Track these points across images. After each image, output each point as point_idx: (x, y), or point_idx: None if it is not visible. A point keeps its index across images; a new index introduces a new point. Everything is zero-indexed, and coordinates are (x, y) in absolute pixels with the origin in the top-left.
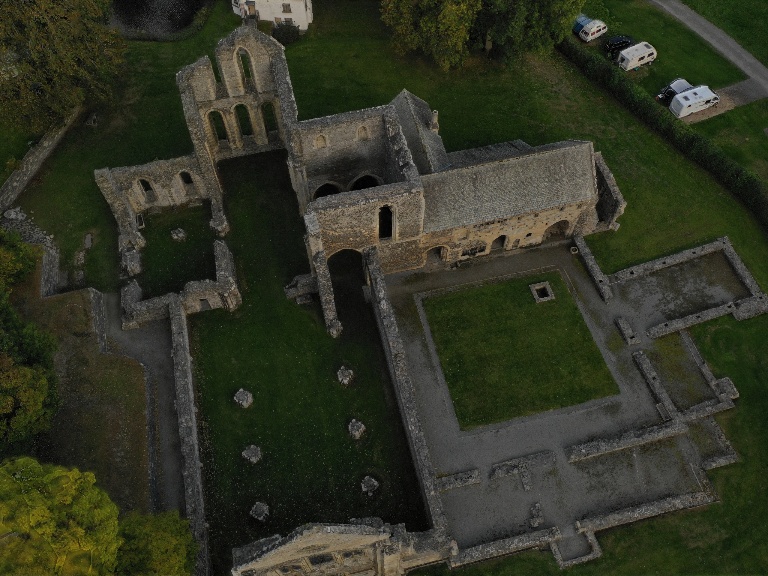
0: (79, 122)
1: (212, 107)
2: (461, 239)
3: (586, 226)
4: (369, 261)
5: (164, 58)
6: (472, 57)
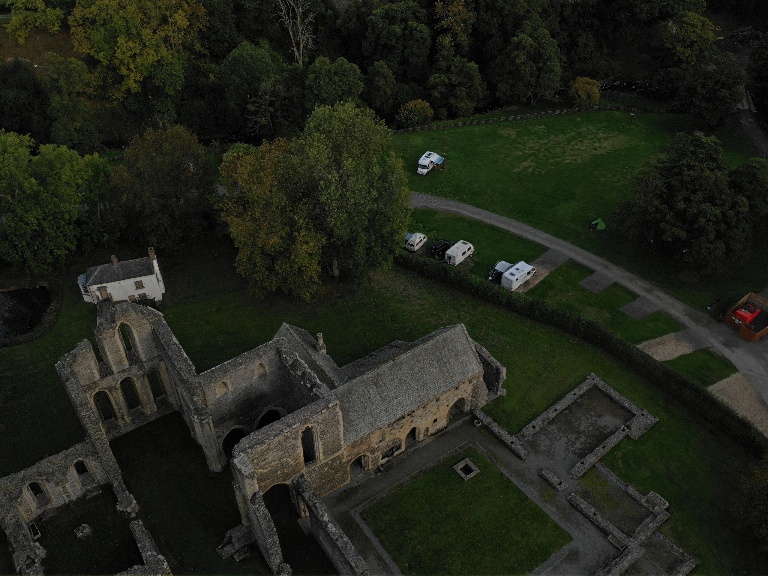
0: None
1: (97, 388)
2: (378, 442)
3: (480, 398)
4: (302, 489)
5: (21, 360)
6: (325, 286)
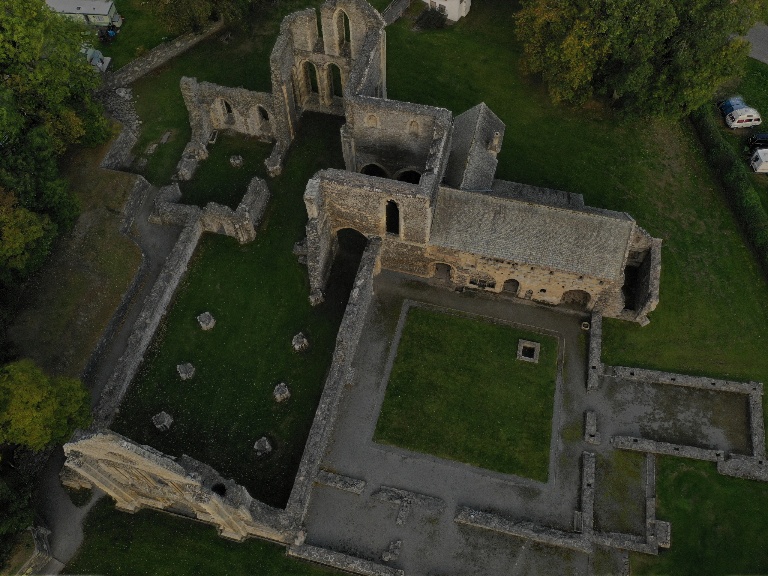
0: (216, 36)
1: (308, 58)
2: (469, 265)
3: (609, 307)
4: (367, 248)
5: (315, 5)
6: (595, 100)
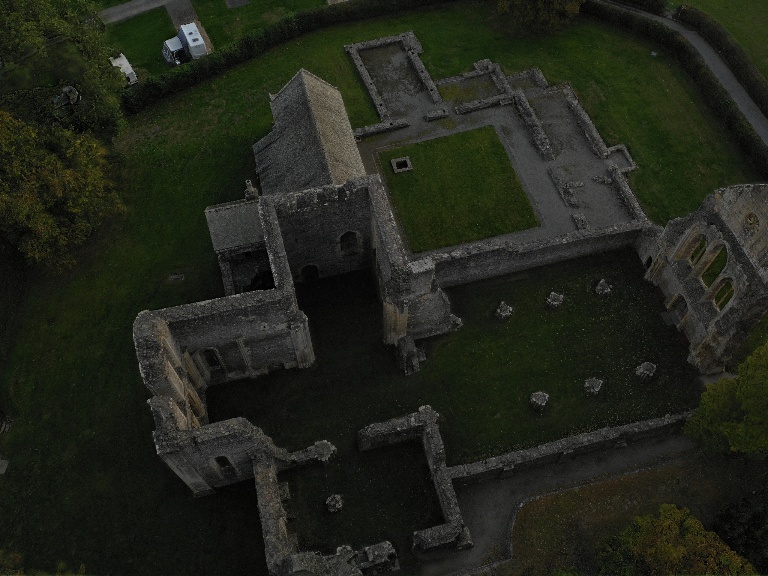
0: None
1: None
2: None
3: None
4: None
5: None
6: None
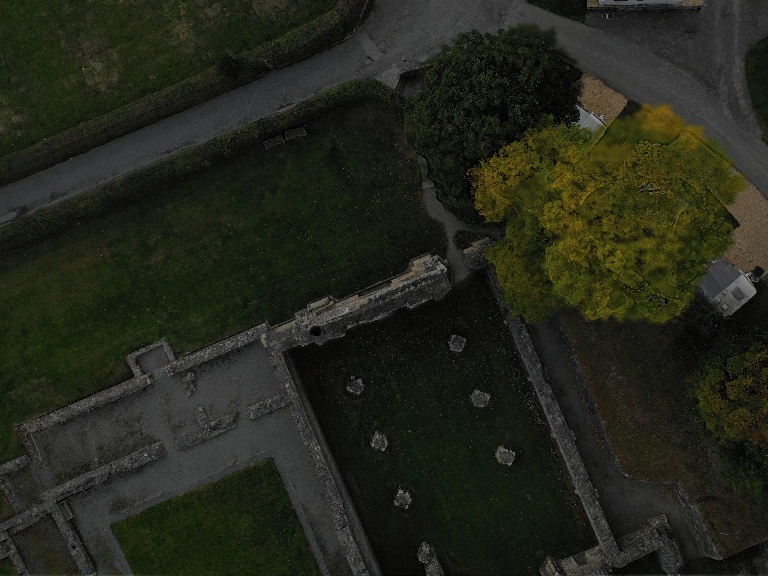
0: None
1: None
2: None
3: None
4: None
5: None
6: None
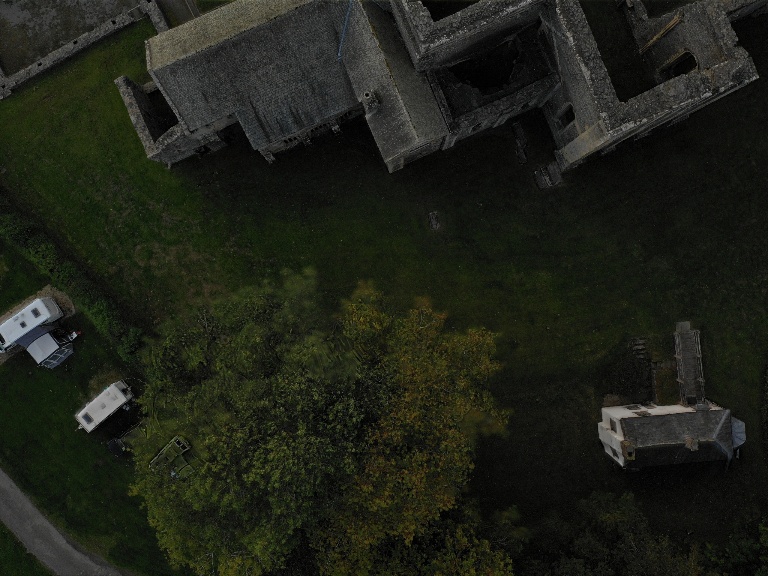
0: None
1: None
2: None
3: None
4: None
5: None
6: None
